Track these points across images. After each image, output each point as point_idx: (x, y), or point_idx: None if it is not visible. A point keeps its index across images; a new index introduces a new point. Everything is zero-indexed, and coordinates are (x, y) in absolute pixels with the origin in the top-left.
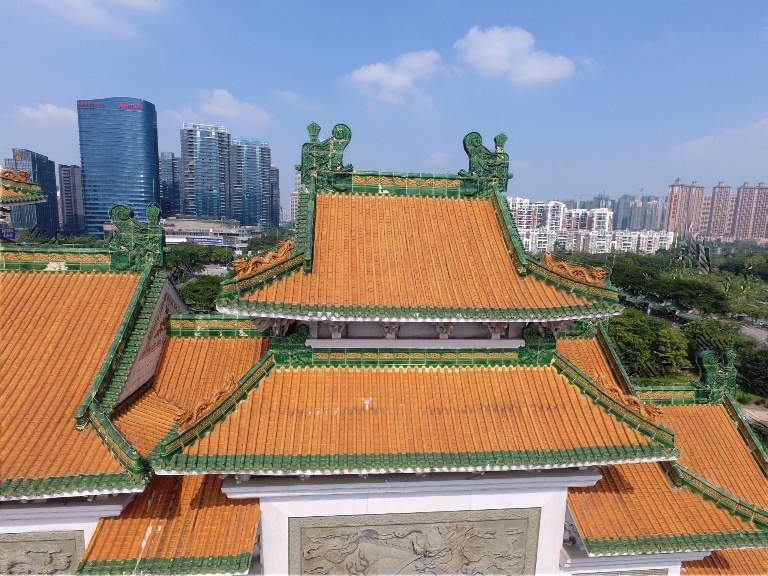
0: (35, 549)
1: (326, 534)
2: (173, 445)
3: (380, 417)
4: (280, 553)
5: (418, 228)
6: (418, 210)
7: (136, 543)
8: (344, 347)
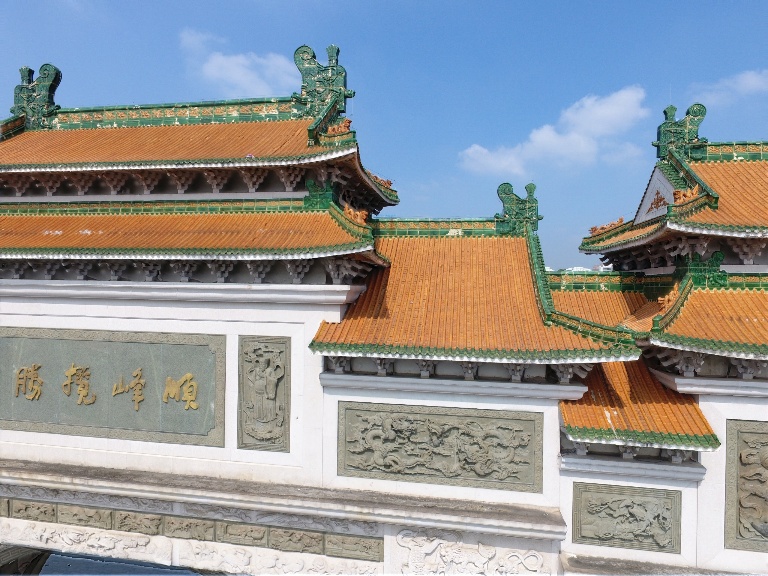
0: (504, 425)
1: (764, 440)
2: (660, 323)
3: None
4: (718, 454)
5: None
6: None
7: (602, 420)
8: (757, 272)
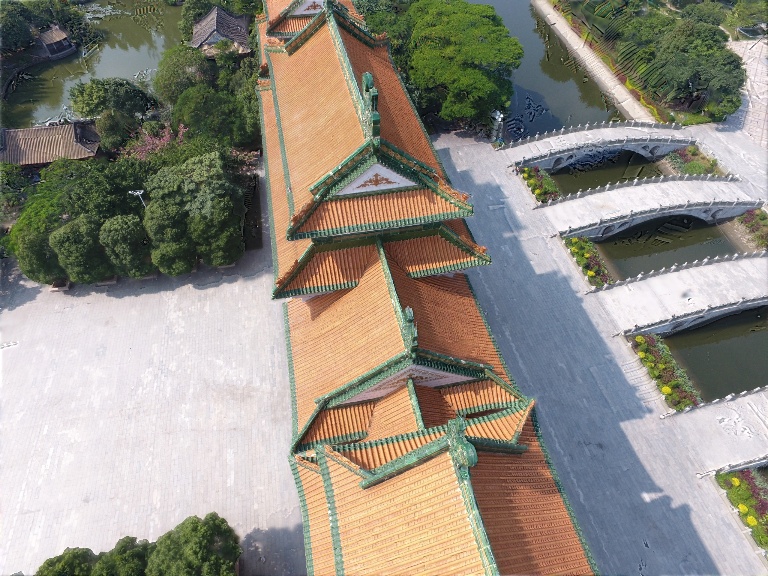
0: None
1: None
2: (293, 460)
3: (334, 570)
4: None
5: (437, 575)
6: (465, 570)
7: (313, 451)
8: None
